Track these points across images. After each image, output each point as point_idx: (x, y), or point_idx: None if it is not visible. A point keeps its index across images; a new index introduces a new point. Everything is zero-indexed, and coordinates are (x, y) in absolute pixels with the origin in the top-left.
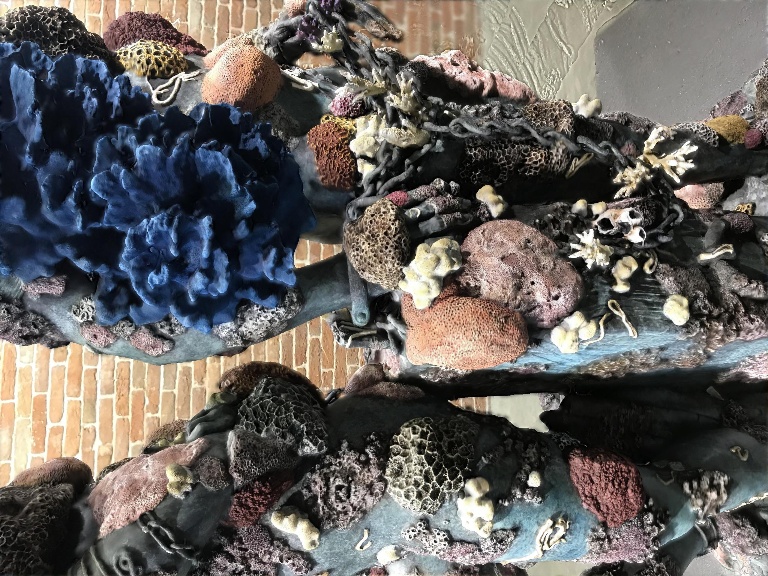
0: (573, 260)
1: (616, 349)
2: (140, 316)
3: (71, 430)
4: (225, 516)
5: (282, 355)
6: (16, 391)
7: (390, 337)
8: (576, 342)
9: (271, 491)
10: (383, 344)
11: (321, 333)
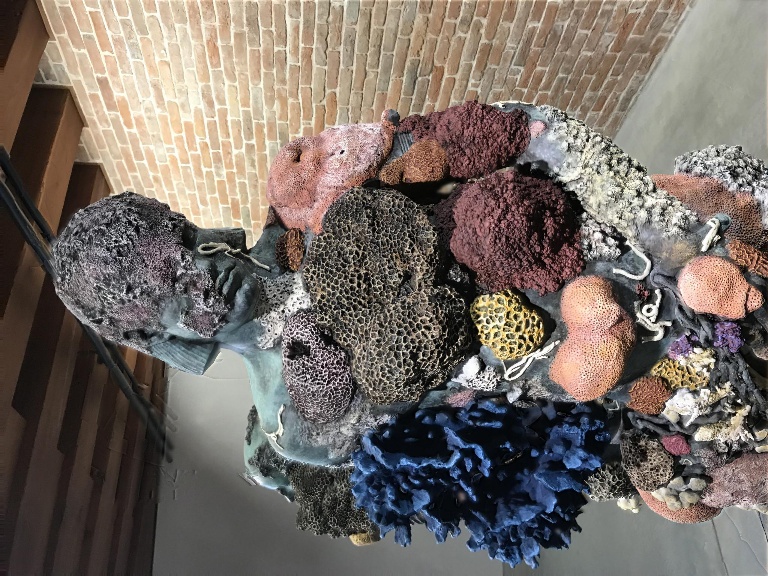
0: None
1: None
2: None
3: None
4: None
5: None
6: None
7: None
8: None
9: None
10: None
11: None
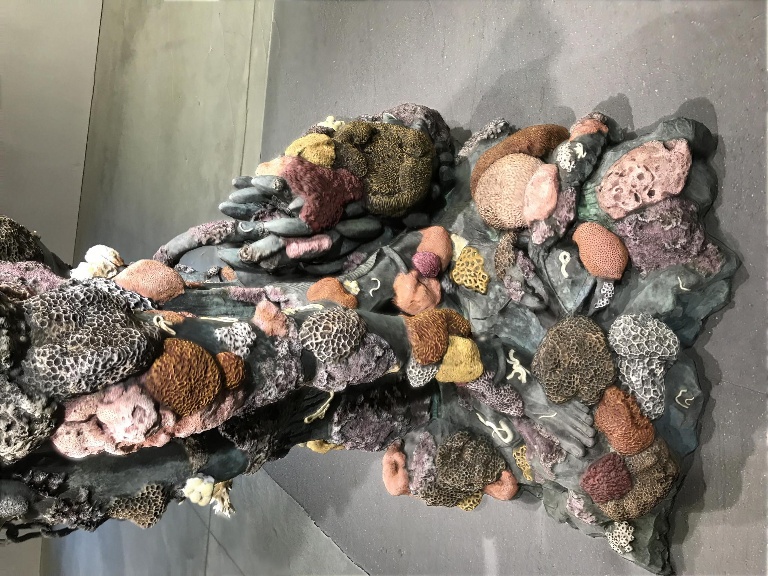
0: None
1: None
2: None
3: None
4: None
5: None
6: None
7: None
8: None
9: None
10: None
11: None
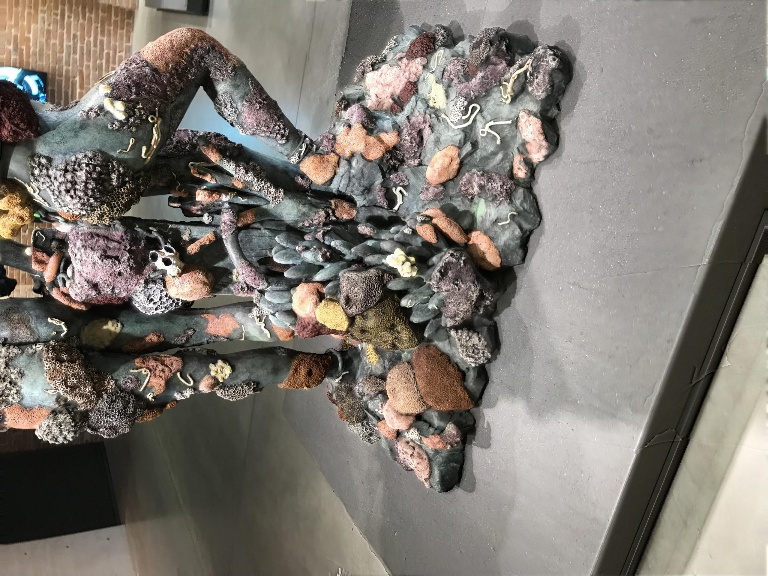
0: None
1: None
2: None
3: None
4: None
5: None
6: None
7: None
8: None
9: None
10: None
11: None
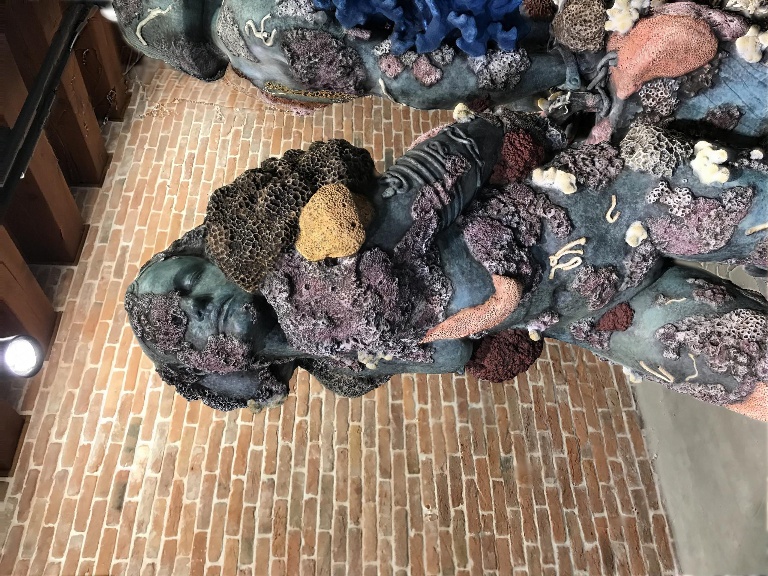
0: (737, 14)
1: None
2: (423, 41)
3: (228, 571)
4: (498, 158)
5: (438, 495)
6: (180, 527)
7: (601, 90)
8: (759, 44)
9: (532, 142)
10: (596, 97)
11: (476, 473)
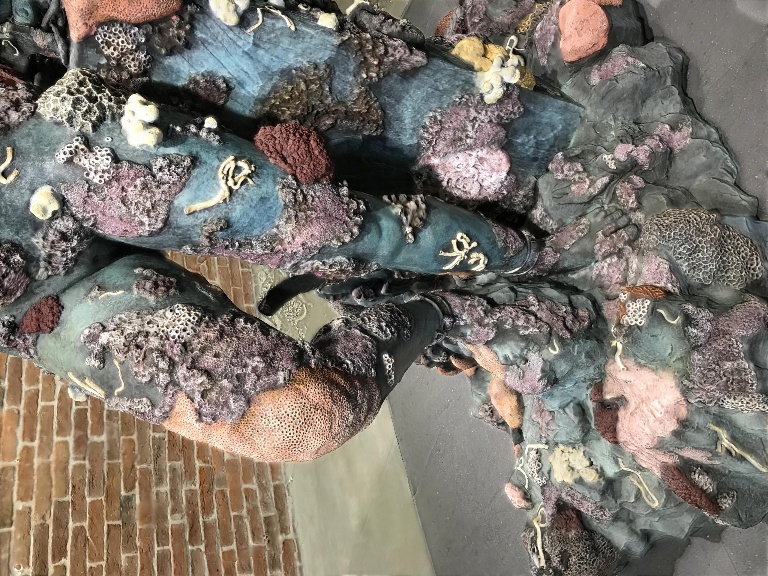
0: None
1: (285, 59)
2: None
3: None
4: None
5: (33, 551)
6: None
7: (54, 27)
8: (232, 3)
9: None
10: (47, 36)
11: (87, 518)
